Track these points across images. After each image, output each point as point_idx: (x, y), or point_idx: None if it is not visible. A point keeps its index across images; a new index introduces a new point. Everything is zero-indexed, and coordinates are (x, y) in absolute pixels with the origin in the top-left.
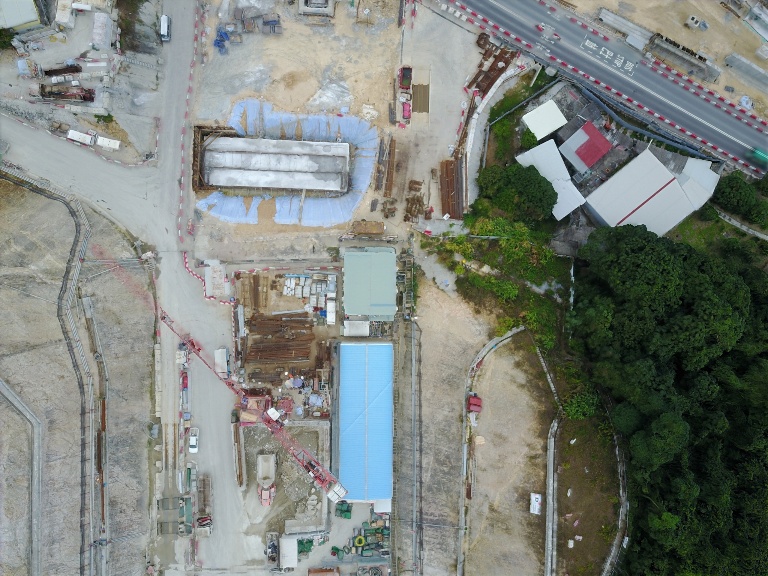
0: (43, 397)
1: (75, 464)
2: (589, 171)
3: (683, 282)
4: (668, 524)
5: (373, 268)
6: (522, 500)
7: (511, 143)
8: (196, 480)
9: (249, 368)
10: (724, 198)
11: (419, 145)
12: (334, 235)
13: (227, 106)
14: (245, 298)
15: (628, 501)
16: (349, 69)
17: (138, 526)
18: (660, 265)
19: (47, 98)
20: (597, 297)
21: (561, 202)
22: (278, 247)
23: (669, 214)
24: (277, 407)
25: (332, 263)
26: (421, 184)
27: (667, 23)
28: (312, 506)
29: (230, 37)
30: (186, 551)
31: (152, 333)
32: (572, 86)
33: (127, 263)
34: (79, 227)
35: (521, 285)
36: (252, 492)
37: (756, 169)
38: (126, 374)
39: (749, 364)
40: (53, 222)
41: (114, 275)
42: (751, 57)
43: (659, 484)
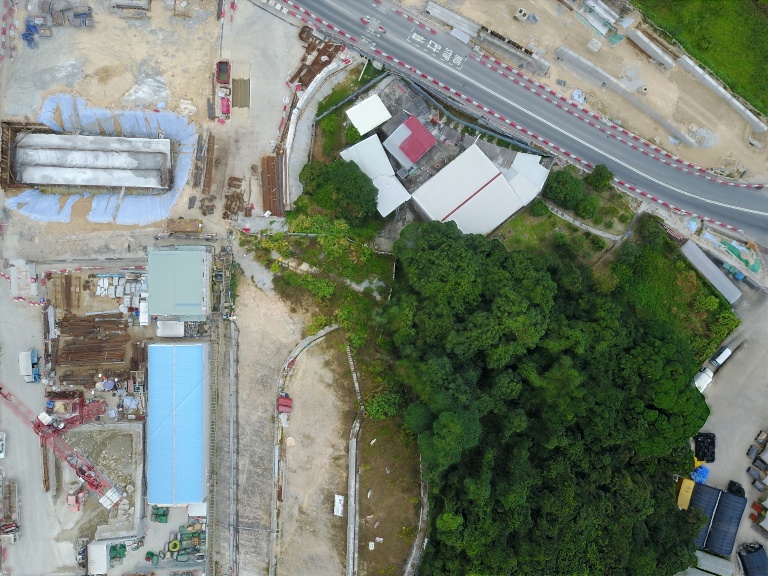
0: None
1: None
2: (415, 166)
3: (480, 279)
4: (449, 525)
5: (178, 267)
6: (327, 502)
7: (339, 138)
8: (2, 486)
9: (60, 370)
10: (552, 193)
11: (239, 141)
12: (150, 233)
13: (38, 102)
14: (56, 299)
15: (428, 502)
16: (166, 63)
17: None
18: (455, 262)
19: None
20: (404, 295)
21: (386, 198)
22: (92, 246)
23: (496, 210)
24: None
25: None
26: (241, 181)
27: (496, 16)
28: (123, 511)
29: (39, 31)
30: None
31: None
32: (401, 80)
33: None
34: None
35: (340, 283)
36: (63, 497)
37: (588, 163)
38: None
39: (554, 361)
40: None
41: None
42: (582, 50)
43: (455, 484)
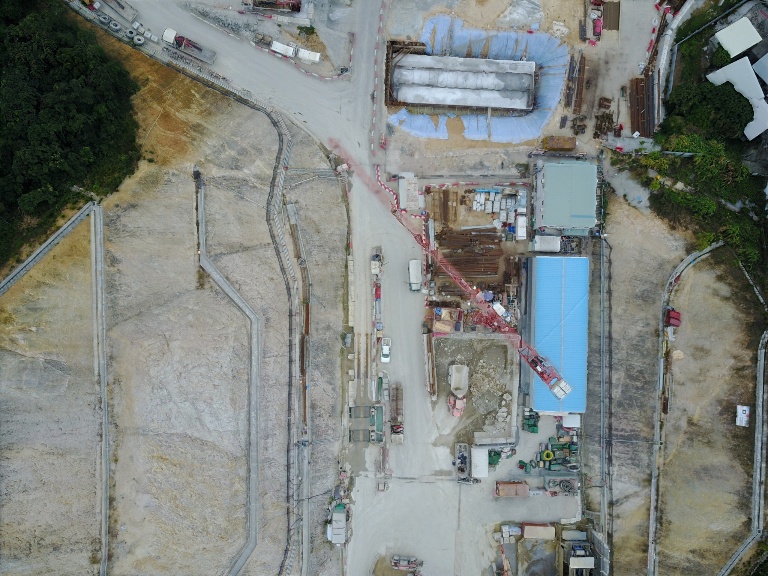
0: (258, 296)
1: (284, 364)
2: None
3: None
4: None
5: (573, 179)
6: (727, 413)
7: (698, 63)
8: (388, 389)
9: (439, 281)
10: None
11: (609, 62)
12: (523, 151)
13: (419, 22)
14: (435, 212)
15: None
16: None
17: (333, 432)
18: None
19: (257, 7)
20: None
21: (754, 121)
22: (467, 163)
23: None
24: (466, 320)
25: (521, 179)
26: (610, 102)
27: None
28: (502, 418)
29: None
30: (376, 459)
31: (345, 244)
32: (762, 5)
33: (324, 174)
34: (281, 136)
35: (715, 203)
36: (441, 403)
37: None
38: (324, 282)
39: None
40: (258, 130)
41: (313, 185)
42: None
43: None
